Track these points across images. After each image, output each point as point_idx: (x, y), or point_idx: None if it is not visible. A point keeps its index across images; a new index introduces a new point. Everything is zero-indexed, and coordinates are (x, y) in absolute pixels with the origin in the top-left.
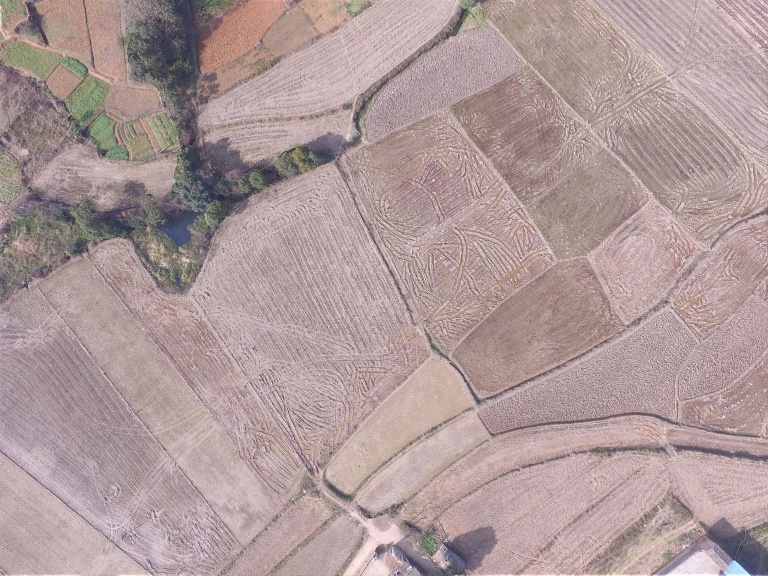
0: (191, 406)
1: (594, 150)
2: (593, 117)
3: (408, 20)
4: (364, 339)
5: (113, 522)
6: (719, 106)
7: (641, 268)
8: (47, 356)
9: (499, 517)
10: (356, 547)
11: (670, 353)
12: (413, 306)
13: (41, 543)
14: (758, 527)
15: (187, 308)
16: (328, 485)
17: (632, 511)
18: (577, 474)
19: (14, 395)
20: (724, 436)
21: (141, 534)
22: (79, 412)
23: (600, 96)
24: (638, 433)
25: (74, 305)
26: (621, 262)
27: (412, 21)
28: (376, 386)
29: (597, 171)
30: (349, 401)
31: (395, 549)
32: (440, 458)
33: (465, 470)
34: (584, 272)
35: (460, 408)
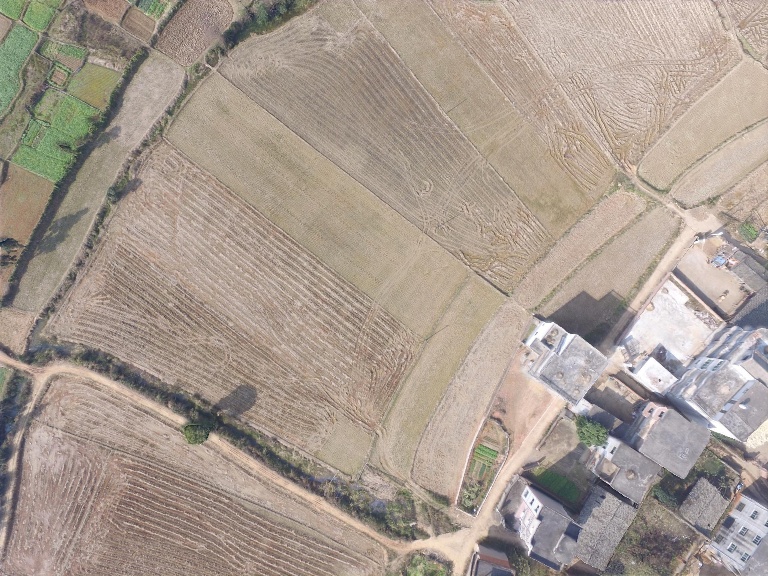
0: (501, 107)
1: None
2: None
3: None
4: (675, 44)
5: (426, 215)
6: None
7: None
8: (357, 58)
9: None
10: (673, 236)
11: None
12: (725, 12)
13: (355, 233)
14: None
15: (495, 14)
16: (642, 180)
17: None
18: None
19: (325, 94)
20: None
21: (454, 226)
22: (390, 111)
23: None
24: None
25: (383, 10)
26: None
27: None
28: (687, 89)
29: None
30: (660, 103)
31: (717, 233)
32: (755, 154)
33: None
34: None
35: None
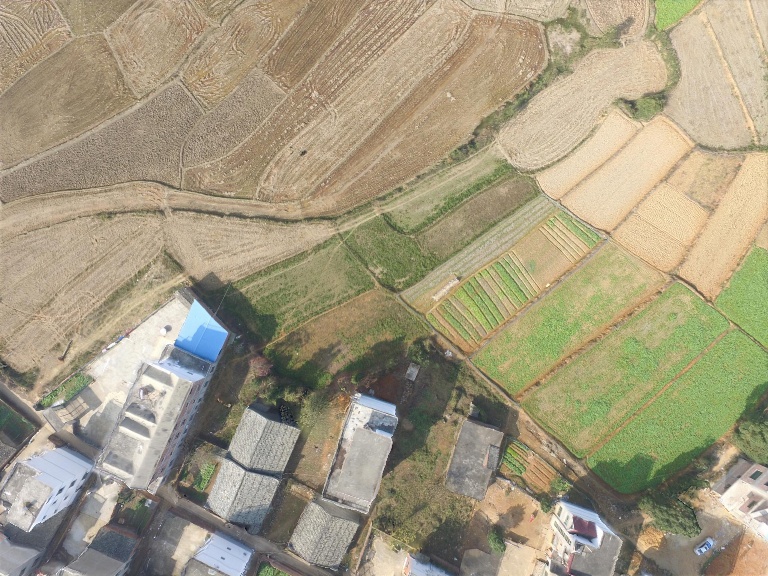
0: None
1: None
2: None
3: None
4: None
5: None
6: None
7: (154, 44)
8: None
9: (4, 278)
10: None
11: (177, 124)
12: None
13: None
14: (242, 279)
15: None
16: None
17: (128, 268)
18: (80, 236)
19: None
20: (221, 199)
21: None
22: None
23: None
24: (141, 198)
25: None
26: (135, 38)
27: None
28: None
29: None
30: None
31: None
32: None
33: None
34: (100, 48)
35: None
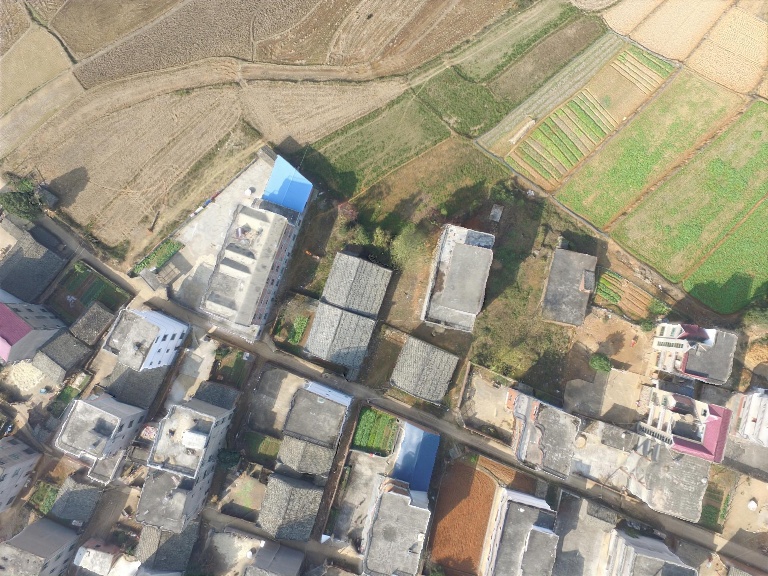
0: None
1: None
2: None
3: None
4: None
5: None
6: None
7: None
8: None
9: (91, 158)
10: None
11: (245, 1)
12: None
13: None
14: (319, 140)
15: None
16: None
17: (208, 139)
18: (160, 113)
19: None
20: (292, 67)
21: None
22: None
23: None
24: (216, 73)
25: None
26: None
27: None
28: None
29: None
30: None
31: None
32: (39, 114)
33: (61, 122)
34: None
35: (59, 70)
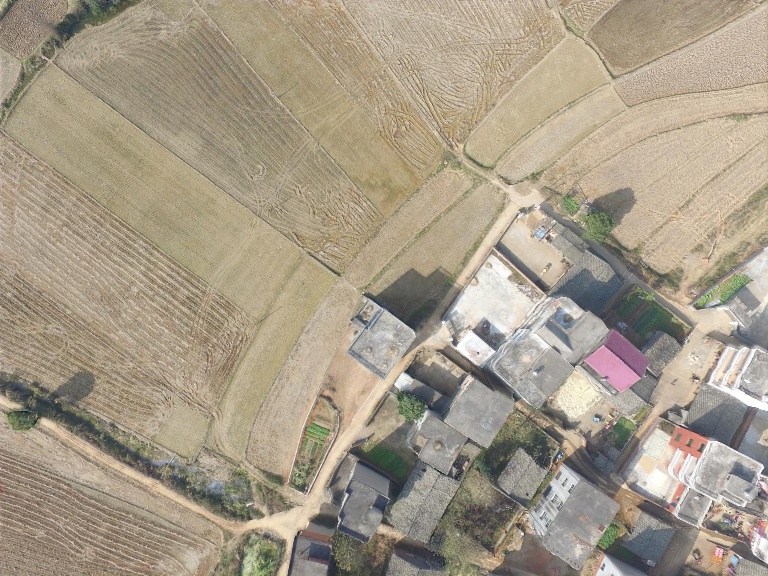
0: (332, 90)
1: None
2: None
3: None
4: (500, 24)
5: (259, 198)
6: None
7: None
8: (191, 46)
9: (638, 179)
10: (498, 212)
11: None
12: None
13: (190, 219)
14: None
15: None
16: (468, 157)
17: None
18: (714, 137)
19: (160, 83)
20: None
21: (287, 209)
22: (223, 98)
23: None
24: None
25: None
26: None
27: None
28: (512, 67)
29: None
30: (486, 82)
31: None
32: (578, 129)
33: (603, 138)
34: None
35: (596, 84)
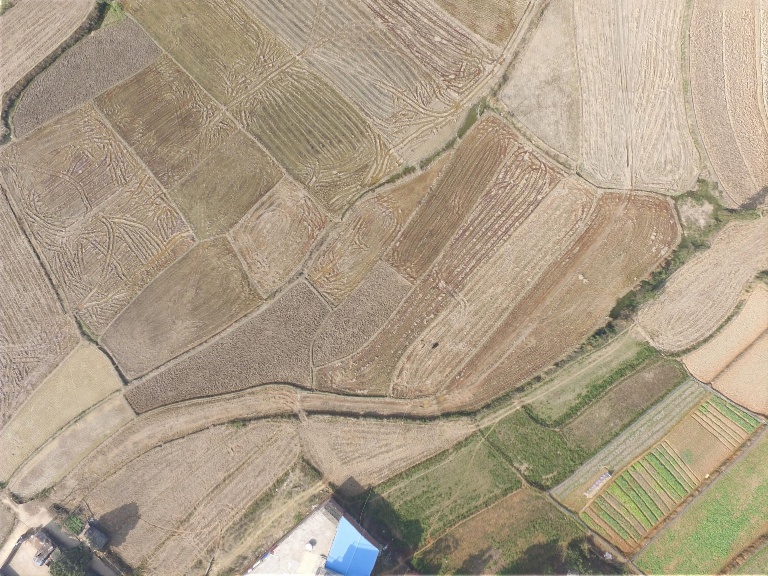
0: None
1: (230, 132)
2: (228, 100)
3: (49, 18)
4: (17, 330)
5: None
6: (346, 81)
7: (277, 243)
8: None
9: (142, 493)
10: (8, 533)
11: (304, 322)
12: (63, 295)
13: None
14: (383, 483)
15: None
16: None
17: (266, 477)
18: (215, 445)
19: None
20: (354, 398)
21: None
22: None
23: (234, 79)
24: (274, 402)
25: None
26: (258, 238)
27: (53, 18)
28: (30, 375)
29: (234, 152)
30: (4, 392)
31: (39, 531)
32: (88, 440)
33: (111, 450)
34: (224, 250)
35: (109, 390)
